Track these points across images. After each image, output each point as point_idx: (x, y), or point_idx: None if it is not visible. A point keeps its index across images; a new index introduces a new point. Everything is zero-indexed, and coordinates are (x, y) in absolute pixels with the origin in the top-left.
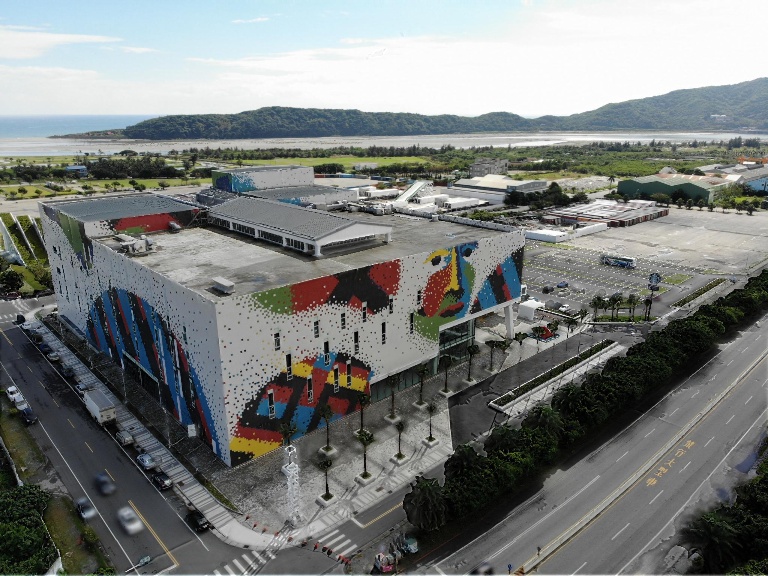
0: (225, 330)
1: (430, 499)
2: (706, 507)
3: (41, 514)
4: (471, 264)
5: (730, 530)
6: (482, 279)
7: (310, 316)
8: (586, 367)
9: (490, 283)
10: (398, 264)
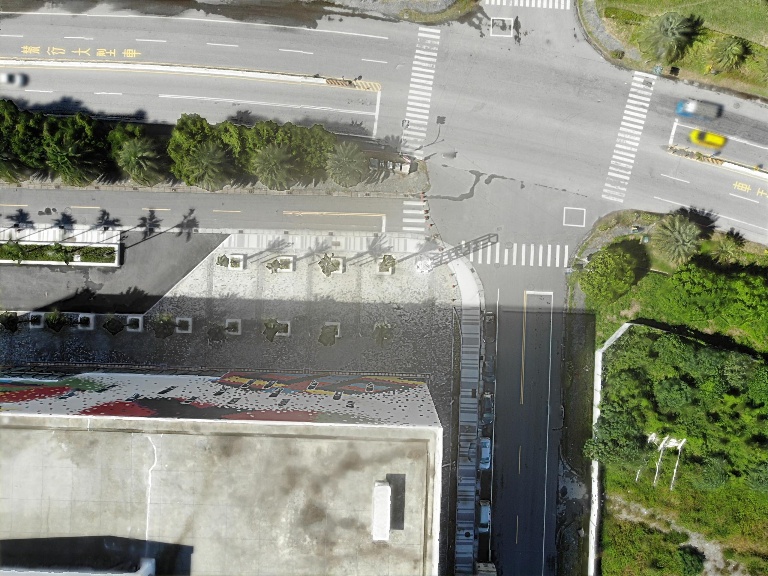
0: None
1: None
2: (133, 1)
3: None
4: None
5: None
6: None
7: None
8: None
9: None
10: None
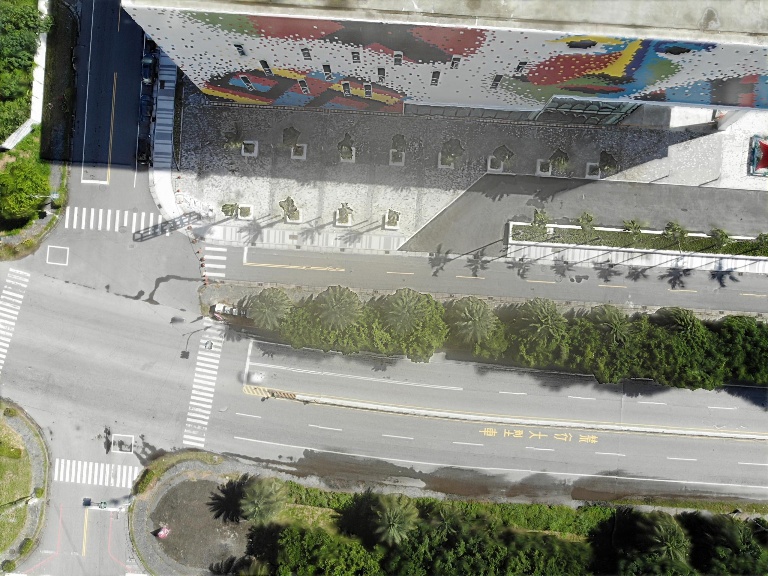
0: (152, 27)
1: (256, 324)
2: (485, 483)
3: (34, 52)
4: (675, 61)
5: (395, 539)
6: (693, 78)
7: (293, 43)
8: (705, 263)
9: (711, 84)
10: (482, 32)
